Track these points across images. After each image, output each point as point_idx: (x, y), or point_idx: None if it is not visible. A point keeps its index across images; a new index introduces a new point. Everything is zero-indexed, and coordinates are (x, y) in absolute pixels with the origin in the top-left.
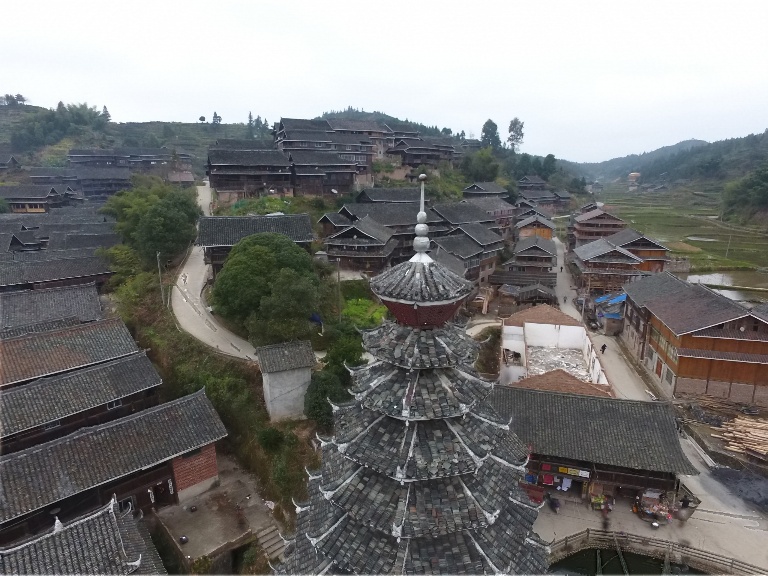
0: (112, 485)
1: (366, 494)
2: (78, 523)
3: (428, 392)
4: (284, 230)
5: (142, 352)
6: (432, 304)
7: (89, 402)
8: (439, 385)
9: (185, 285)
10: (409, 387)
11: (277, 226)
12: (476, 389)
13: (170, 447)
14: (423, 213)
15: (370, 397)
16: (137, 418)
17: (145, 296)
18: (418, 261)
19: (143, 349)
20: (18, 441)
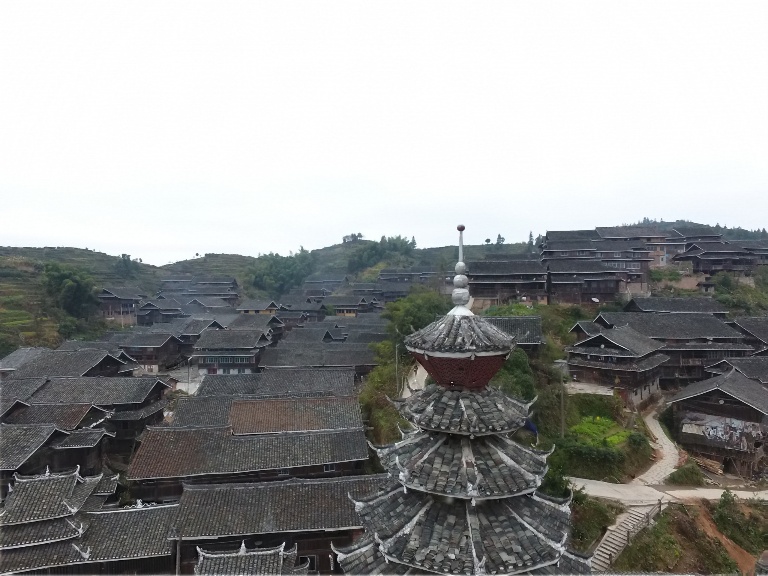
0: (302, 537)
1: (370, 569)
2: (256, 553)
3: (442, 462)
4: (512, 331)
5: (360, 427)
6: (444, 355)
7: (310, 460)
8: (457, 457)
9: (415, 376)
10: (422, 451)
11: (506, 327)
12: (512, 477)
13: (352, 518)
14: (460, 263)
15: (389, 456)
16: (335, 482)
17: (385, 382)
18: (451, 313)
19: (368, 427)
20: (259, 478)
